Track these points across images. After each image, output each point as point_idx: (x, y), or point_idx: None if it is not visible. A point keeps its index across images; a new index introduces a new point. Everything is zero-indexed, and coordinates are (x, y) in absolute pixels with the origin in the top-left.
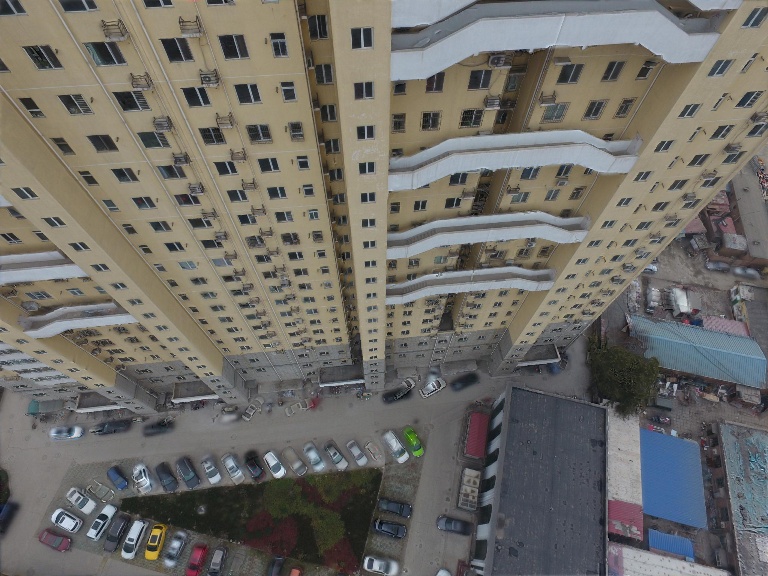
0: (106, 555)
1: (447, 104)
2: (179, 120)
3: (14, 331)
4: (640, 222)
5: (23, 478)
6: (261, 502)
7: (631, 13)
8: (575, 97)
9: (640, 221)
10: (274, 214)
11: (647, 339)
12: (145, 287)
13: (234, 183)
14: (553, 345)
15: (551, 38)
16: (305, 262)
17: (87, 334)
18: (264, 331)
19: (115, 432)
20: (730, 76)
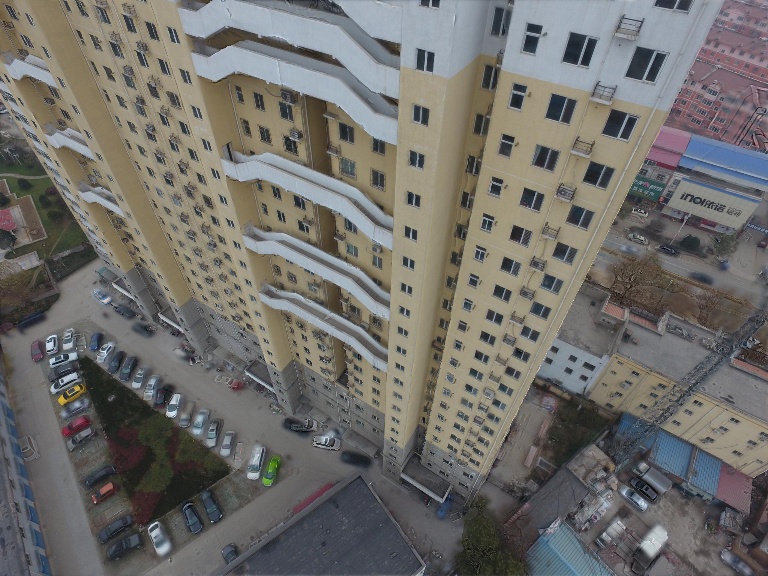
0: (47, 381)
1: (271, 124)
2: (137, 72)
3: (74, 187)
4: (475, 349)
5: (62, 306)
6: (143, 423)
7: (320, 74)
8: (359, 159)
9: (474, 347)
10: (196, 173)
11: (555, 557)
12: (127, 190)
13: (170, 134)
14: (450, 484)
15: (277, 77)
16: (221, 231)
17: (122, 223)
18: (212, 287)
19: (123, 315)
20: (430, 173)
